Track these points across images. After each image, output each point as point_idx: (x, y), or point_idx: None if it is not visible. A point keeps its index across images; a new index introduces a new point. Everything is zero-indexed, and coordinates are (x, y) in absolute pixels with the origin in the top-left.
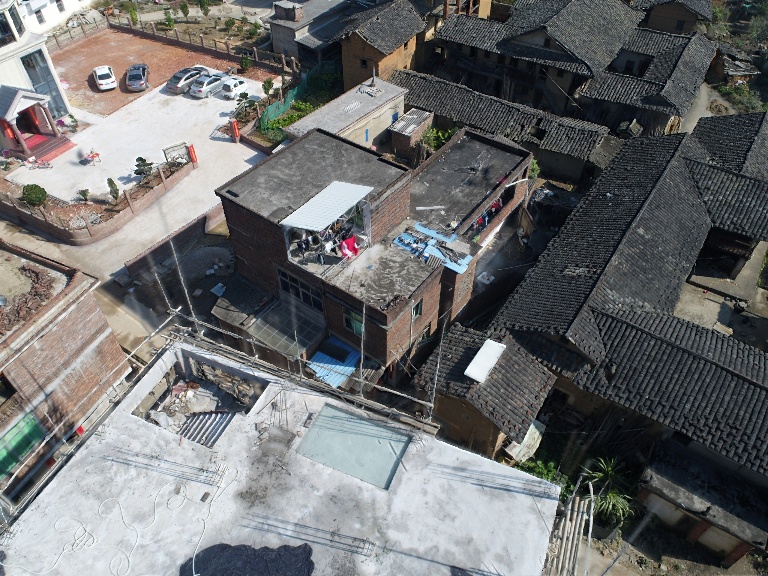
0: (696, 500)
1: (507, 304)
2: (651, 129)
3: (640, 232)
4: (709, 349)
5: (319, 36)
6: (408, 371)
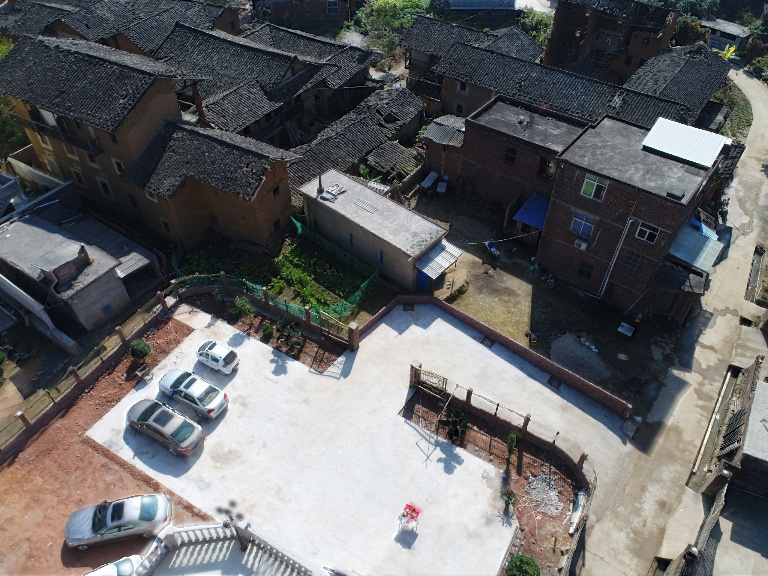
0: (718, 118)
1: None
2: None
3: None
4: None
5: (115, 254)
6: (716, 182)
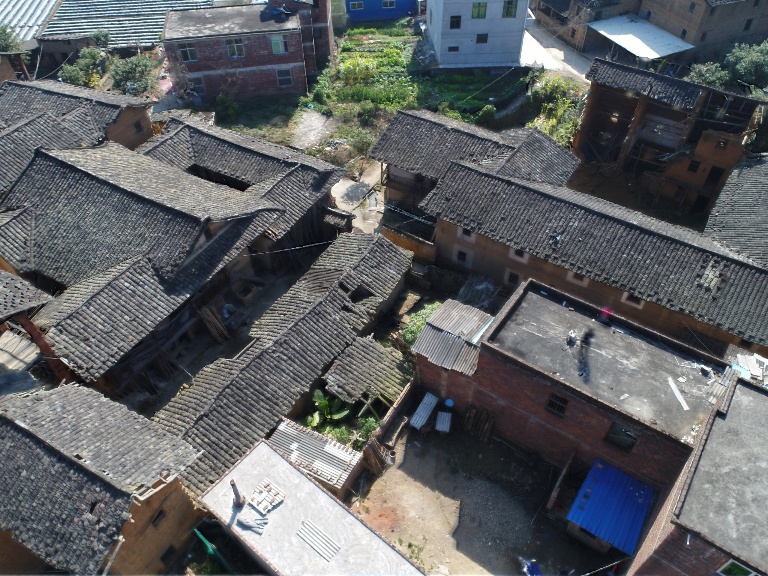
0: None
1: (766, 344)
2: (330, 204)
3: (636, 223)
4: (763, 217)
5: None
6: None
